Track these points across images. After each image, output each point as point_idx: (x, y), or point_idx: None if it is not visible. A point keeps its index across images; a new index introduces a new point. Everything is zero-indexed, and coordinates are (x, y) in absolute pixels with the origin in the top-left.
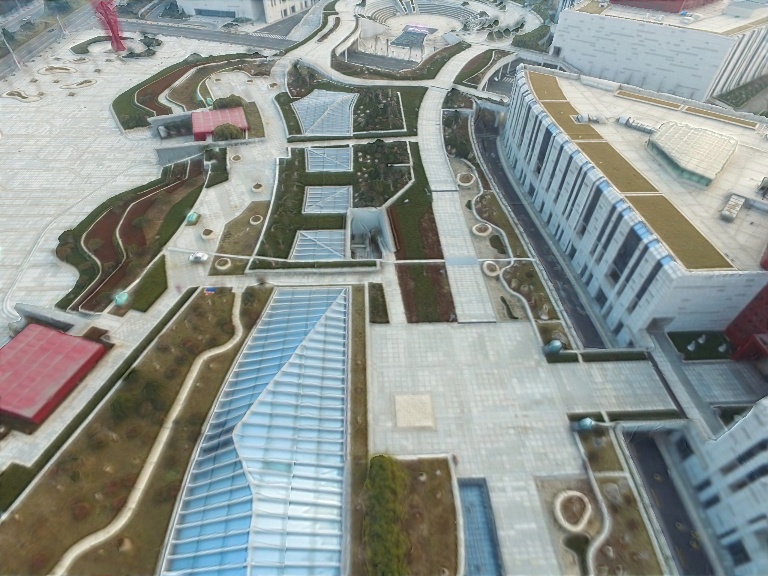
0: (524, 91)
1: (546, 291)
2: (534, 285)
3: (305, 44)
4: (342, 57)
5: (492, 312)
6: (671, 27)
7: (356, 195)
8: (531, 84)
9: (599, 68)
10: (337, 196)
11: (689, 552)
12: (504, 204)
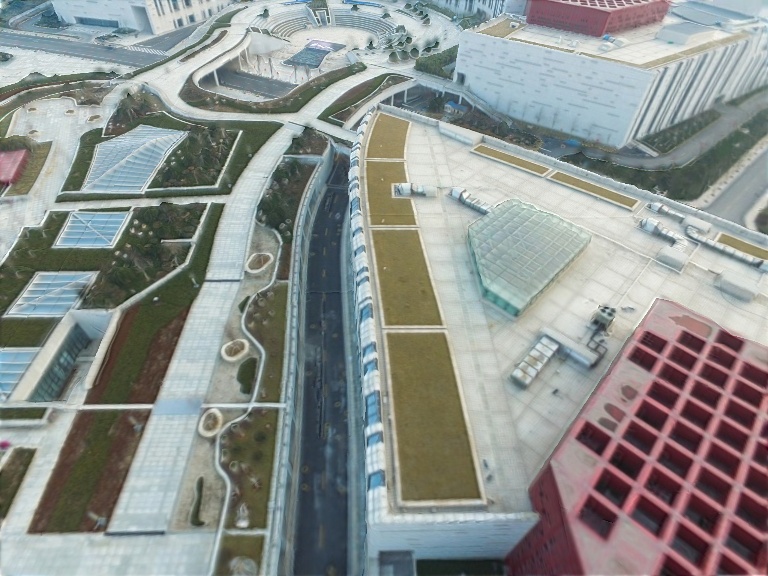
0: (354, 143)
1: (272, 468)
2: (257, 457)
3: (164, 64)
4: (210, 80)
5: (169, 511)
6: (581, 56)
7: (92, 288)
8: (371, 133)
9: (507, 100)
10: (69, 288)
11: None
12: (292, 304)
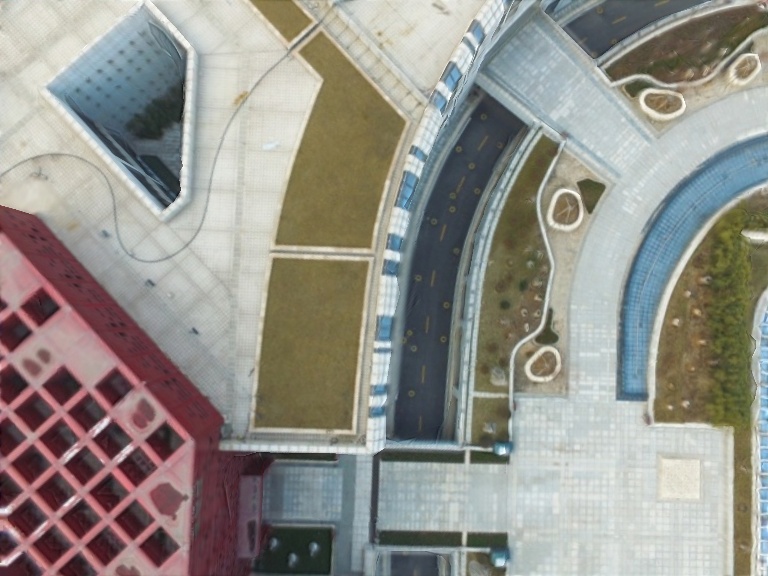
0: None
1: None
2: None
3: None
4: None
5: None
6: None
7: None
8: None
9: None
10: None
11: (418, 327)
12: None
